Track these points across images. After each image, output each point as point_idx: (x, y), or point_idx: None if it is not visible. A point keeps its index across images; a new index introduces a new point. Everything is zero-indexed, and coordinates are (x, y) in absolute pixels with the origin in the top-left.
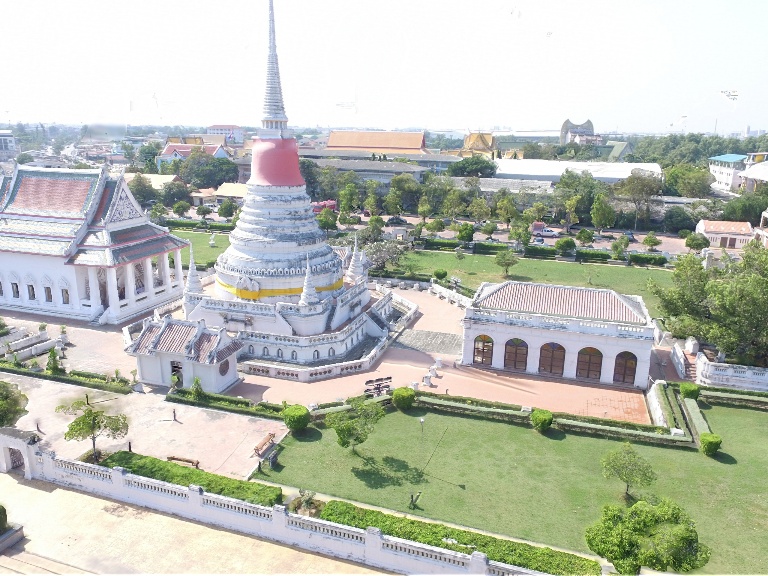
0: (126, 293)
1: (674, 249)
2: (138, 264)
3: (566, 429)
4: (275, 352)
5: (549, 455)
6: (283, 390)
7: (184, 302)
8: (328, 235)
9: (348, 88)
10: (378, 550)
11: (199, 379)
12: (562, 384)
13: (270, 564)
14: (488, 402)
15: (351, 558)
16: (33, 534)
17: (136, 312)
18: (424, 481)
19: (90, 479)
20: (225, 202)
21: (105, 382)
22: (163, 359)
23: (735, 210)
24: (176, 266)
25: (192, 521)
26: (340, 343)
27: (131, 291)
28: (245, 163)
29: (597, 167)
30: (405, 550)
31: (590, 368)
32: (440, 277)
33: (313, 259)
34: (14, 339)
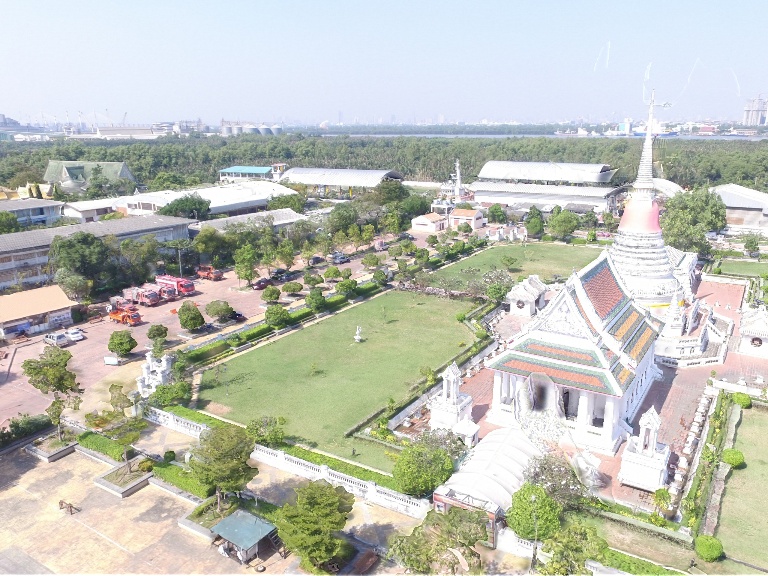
0: None
1: None
2: None
3: None
4: None
5: None
6: None
7: None
8: (351, 295)
9: None
10: None
11: None
12: (699, 288)
13: None
14: None
15: None
16: None
17: None
18: None
19: None
20: (194, 306)
21: None
22: None
23: (414, 206)
24: None
25: None
26: None
27: None
28: None
29: (248, 190)
30: None
31: None
32: None
33: None
34: None
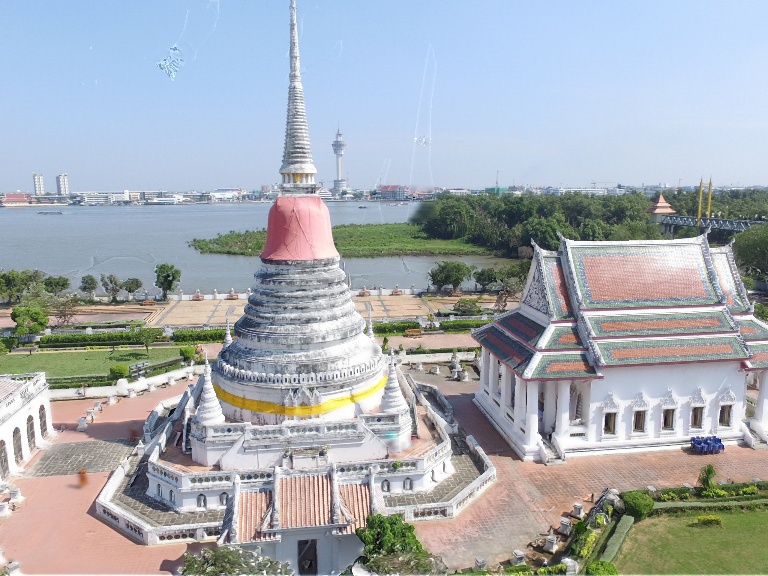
0: None
1: None
2: (571, 390)
3: None
4: None
5: None
6: None
7: None
8: None
9: None
10: None
11: None
12: None
13: None
14: None
15: None
16: None
17: None
18: None
19: None
20: None
21: None
22: None
23: None
24: None
25: None
26: None
27: None
28: None
29: None
30: None
31: None
32: None
33: None
34: None
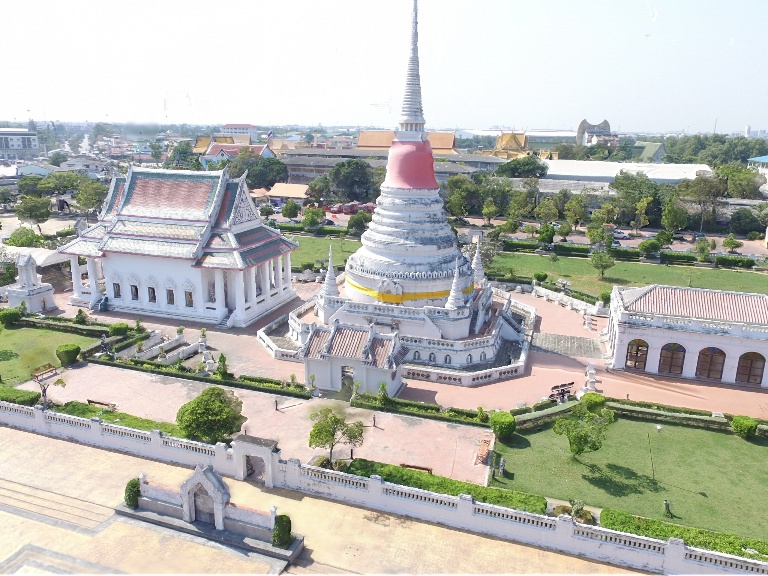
0: (249, 296)
1: (751, 251)
2: None
3: (767, 435)
4: (427, 356)
5: (767, 462)
6: (452, 395)
7: (323, 305)
8: None
9: (382, 88)
10: (680, 560)
11: (385, 384)
12: (724, 389)
13: (569, 575)
14: (675, 408)
15: (647, 568)
16: (311, 544)
17: (258, 315)
18: (662, 489)
19: (342, 487)
20: (290, 203)
21: (280, 387)
22: (334, 364)
23: None
24: (286, 268)
25: (462, 530)
26: (491, 347)
27: (254, 294)
28: (293, 163)
29: (647, 168)
30: (711, 561)
31: (751, 373)
32: (541, 279)
33: (451, 262)
34: (154, 342)
